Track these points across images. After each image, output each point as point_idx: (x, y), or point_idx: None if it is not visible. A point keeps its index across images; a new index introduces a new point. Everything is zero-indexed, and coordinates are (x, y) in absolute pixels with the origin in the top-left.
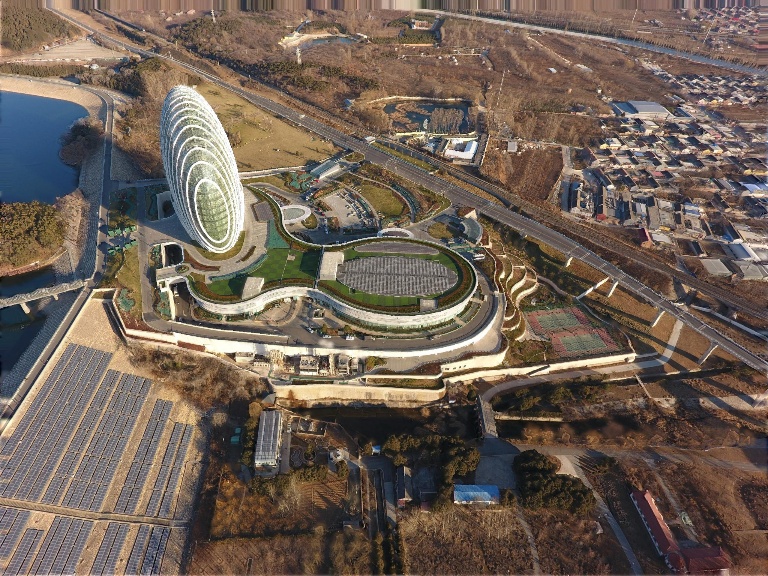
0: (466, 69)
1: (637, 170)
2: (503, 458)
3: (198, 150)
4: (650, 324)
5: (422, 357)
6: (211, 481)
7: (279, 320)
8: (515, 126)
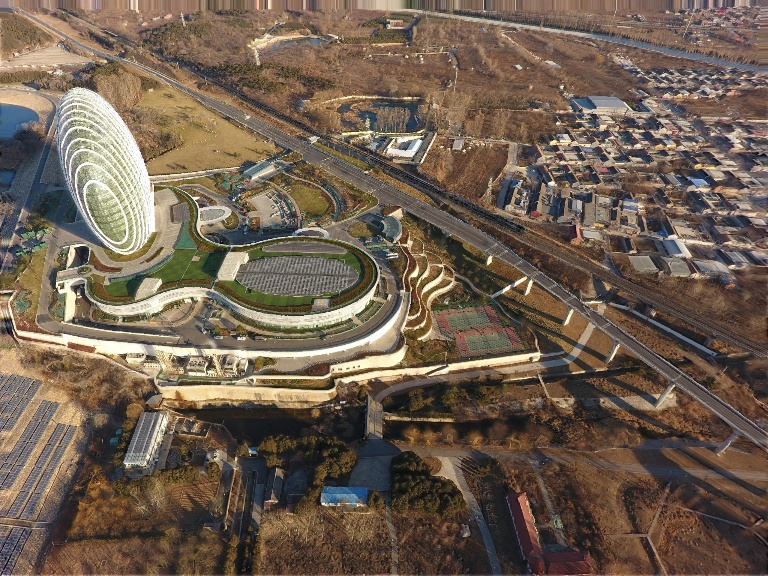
0: (430, 67)
1: (582, 166)
2: (382, 459)
3: (84, 151)
4: (562, 322)
5: (313, 357)
6: (81, 482)
7: (175, 321)
8: (466, 124)
